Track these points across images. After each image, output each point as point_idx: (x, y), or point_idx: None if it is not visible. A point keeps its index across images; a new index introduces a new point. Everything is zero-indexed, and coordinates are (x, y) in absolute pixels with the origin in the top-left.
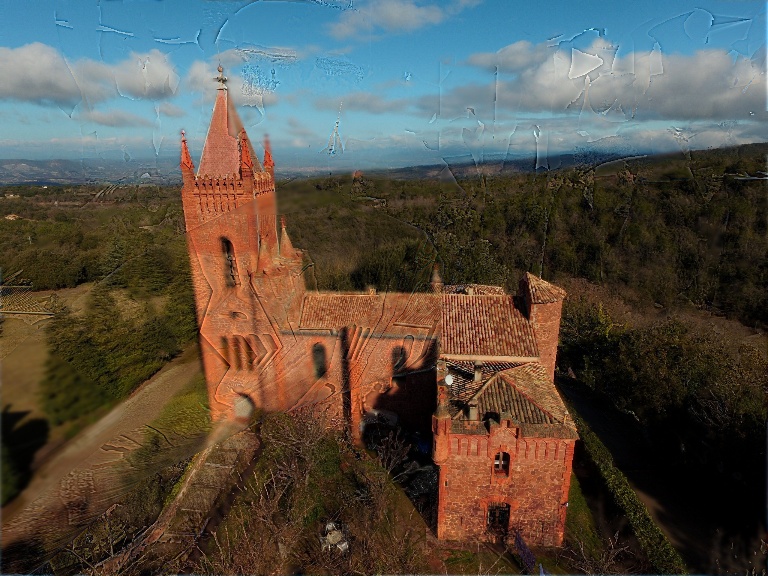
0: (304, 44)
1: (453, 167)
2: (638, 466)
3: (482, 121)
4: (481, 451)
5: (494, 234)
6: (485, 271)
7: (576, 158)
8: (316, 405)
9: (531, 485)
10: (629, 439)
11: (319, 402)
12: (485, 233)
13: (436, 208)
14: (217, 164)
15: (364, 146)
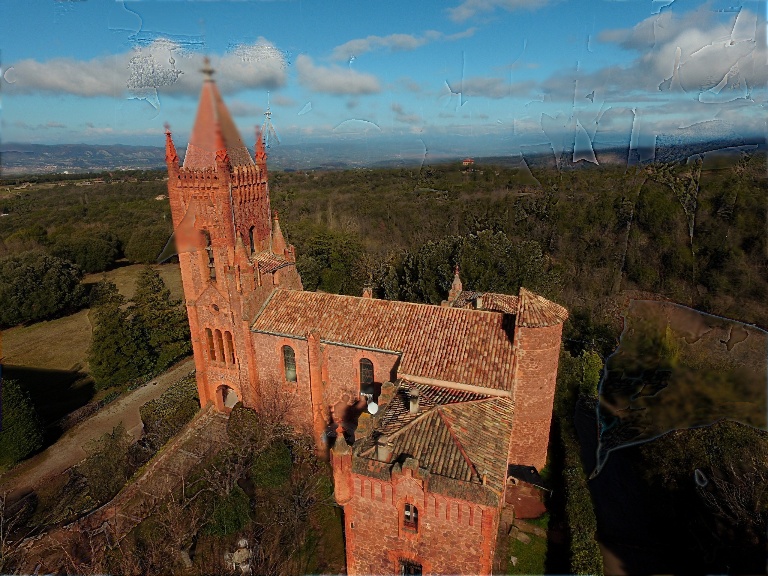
0: (211, 29)
1: (529, 157)
2: (642, 541)
3: (559, 105)
4: (386, 498)
5: (573, 233)
6: (531, 276)
7: (661, 148)
8: (288, 408)
9: (444, 548)
10: (648, 502)
11: (290, 405)
12: (563, 231)
13: (512, 201)
14: (200, 157)
15: (434, 134)
